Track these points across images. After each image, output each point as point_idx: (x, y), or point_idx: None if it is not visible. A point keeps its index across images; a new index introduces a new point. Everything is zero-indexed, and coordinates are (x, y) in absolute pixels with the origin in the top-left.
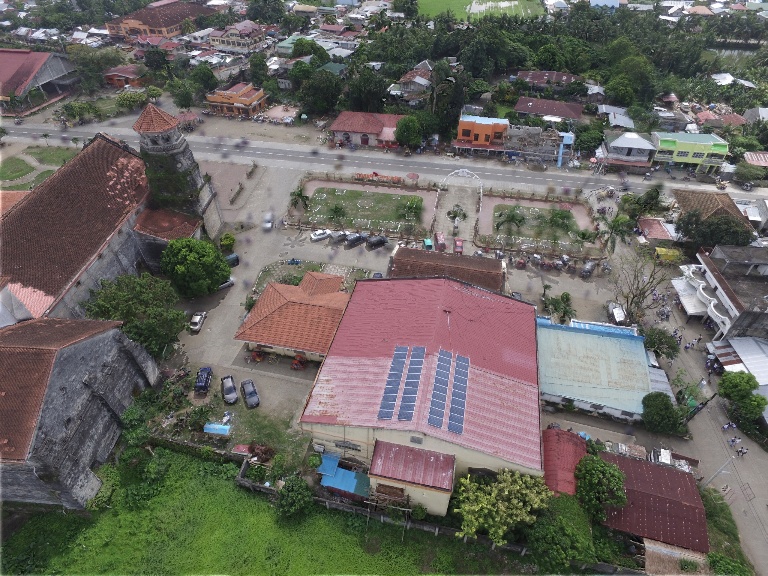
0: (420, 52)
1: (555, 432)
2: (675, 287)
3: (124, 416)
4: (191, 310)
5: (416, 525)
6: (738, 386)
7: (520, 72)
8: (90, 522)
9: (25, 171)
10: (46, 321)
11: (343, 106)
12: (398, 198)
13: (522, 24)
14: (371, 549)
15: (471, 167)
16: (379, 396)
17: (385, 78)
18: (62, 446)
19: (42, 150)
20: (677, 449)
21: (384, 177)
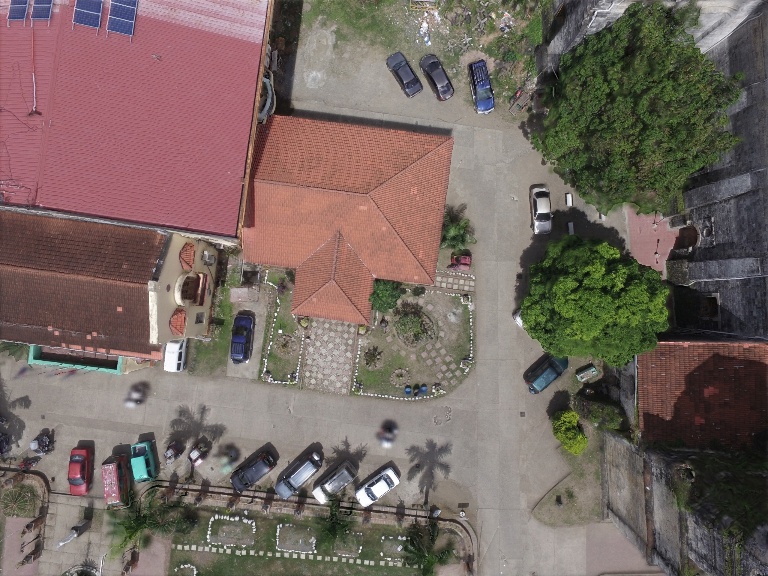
0: None
1: None
2: None
3: None
4: None
5: None
6: None
7: None
8: None
9: None
10: None
11: None
12: None
13: None
14: None
15: None
16: None
17: None
18: None
19: None
20: None
21: None
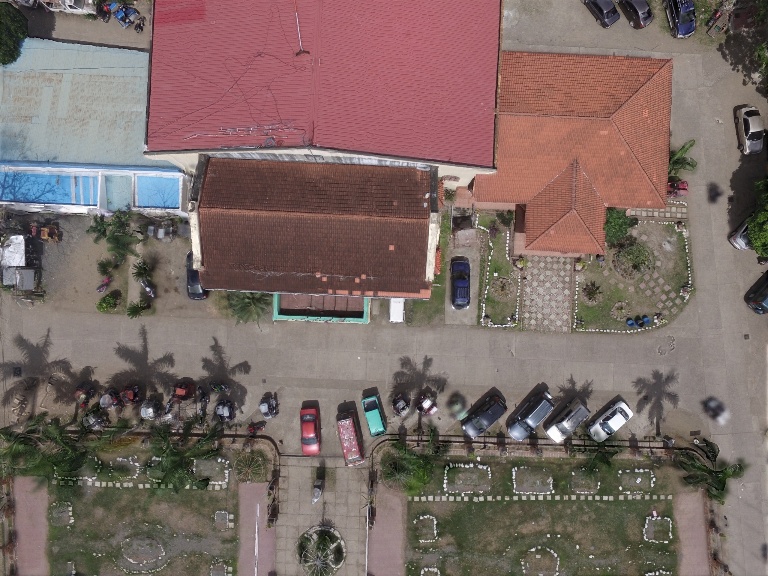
0: None
1: None
2: None
3: None
4: None
5: None
6: None
7: None
8: None
9: None
10: None
11: None
12: None
13: None
14: None
15: None
16: None
17: None
18: None
19: None
20: None
21: None
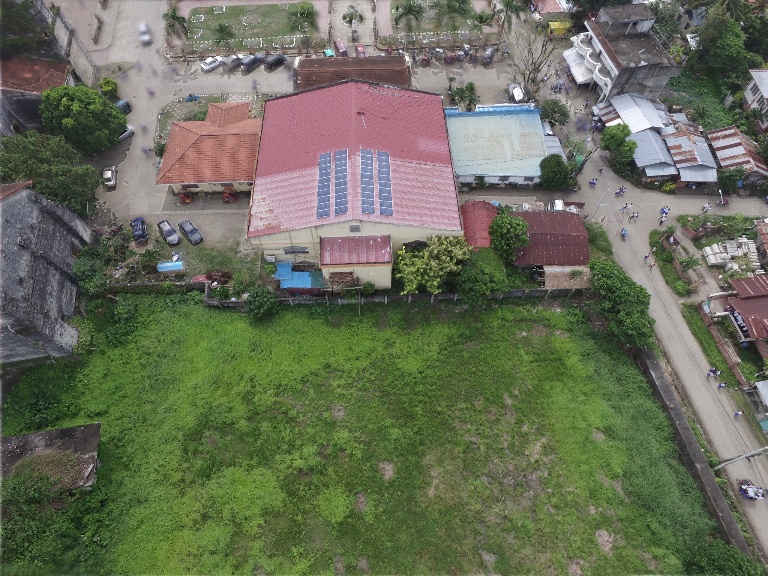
0: None
1: (471, 204)
2: (566, 60)
3: (74, 269)
4: (98, 167)
5: (368, 299)
6: (615, 136)
7: None
8: (82, 364)
9: None
10: None
11: None
12: (286, 8)
13: None
14: (336, 325)
15: None
16: (314, 200)
17: None
18: (26, 303)
19: None
20: (568, 199)
21: None
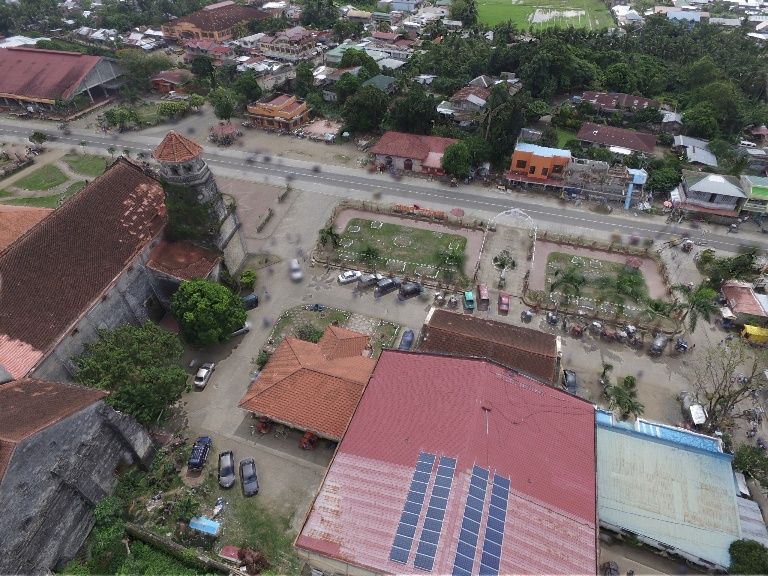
0: (476, 66)
1: None
2: None
3: (97, 510)
4: (199, 359)
5: None
6: None
7: (585, 93)
8: None
9: (58, 181)
10: (26, 385)
11: (389, 123)
12: (439, 237)
13: (590, 38)
14: None
15: (524, 204)
16: (394, 524)
17: (436, 93)
18: (17, 553)
19: (79, 158)
20: None
21: (426, 211)
